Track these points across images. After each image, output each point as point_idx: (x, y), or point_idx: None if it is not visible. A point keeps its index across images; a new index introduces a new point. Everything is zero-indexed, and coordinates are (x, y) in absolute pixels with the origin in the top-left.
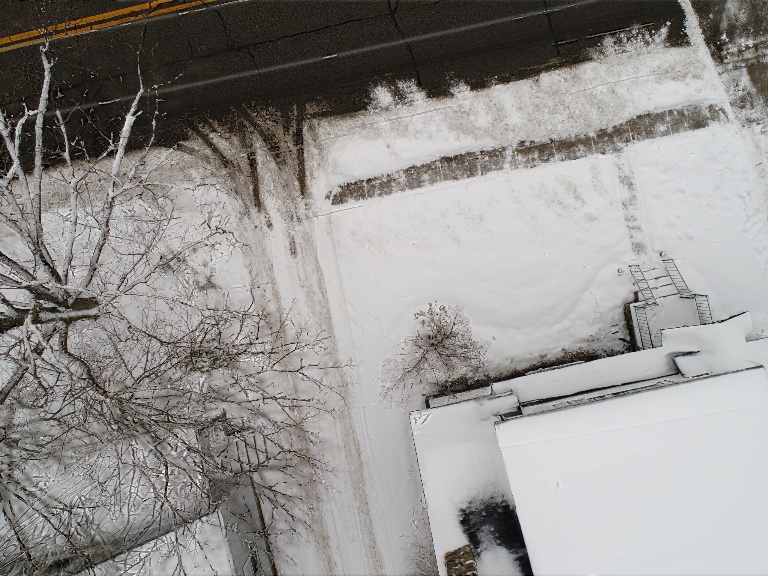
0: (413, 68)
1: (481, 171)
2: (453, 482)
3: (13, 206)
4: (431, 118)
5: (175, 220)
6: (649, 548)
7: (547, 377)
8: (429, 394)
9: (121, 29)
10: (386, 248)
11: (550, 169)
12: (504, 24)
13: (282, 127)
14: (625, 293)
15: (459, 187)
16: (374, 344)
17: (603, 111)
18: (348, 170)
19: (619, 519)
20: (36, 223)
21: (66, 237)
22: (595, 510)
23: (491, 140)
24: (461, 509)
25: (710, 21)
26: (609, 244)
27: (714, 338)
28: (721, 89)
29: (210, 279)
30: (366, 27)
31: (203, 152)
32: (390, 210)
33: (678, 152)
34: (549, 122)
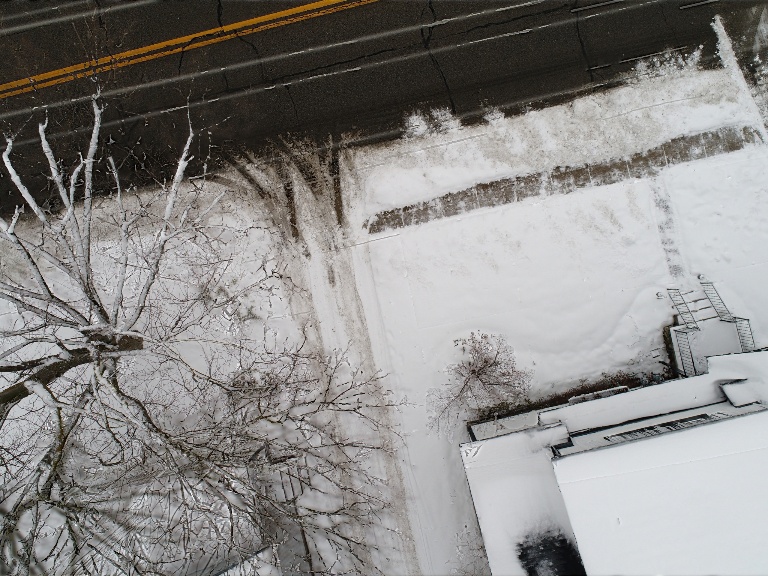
0: (447, 96)
1: (517, 197)
2: (509, 516)
3: (66, 250)
4: (467, 146)
5: None
6: None
7: (595, 406)
8: (470, 420)
9: (156, 63)
10: (424, 276)
11: (586, 194)
12: (537, 51)
13: (318, 157)
14: (664, 316)
15: (496, 214)
16: (414, 371)
17: (638, 136)
18: (385, 199)
19: (681, 555)
20: (86, 265)
21: (106, 270)
22: (657, 547)
23: (527, 167)
24: (518, 544)
25: (743, 43)
26: (647, 268)
27: (762, 366)
28: (755, 111)
29: (251, 310)
30: None
31: (240, 184)
32: (428, 238)
33: (714, 175)
34: (585, 148)
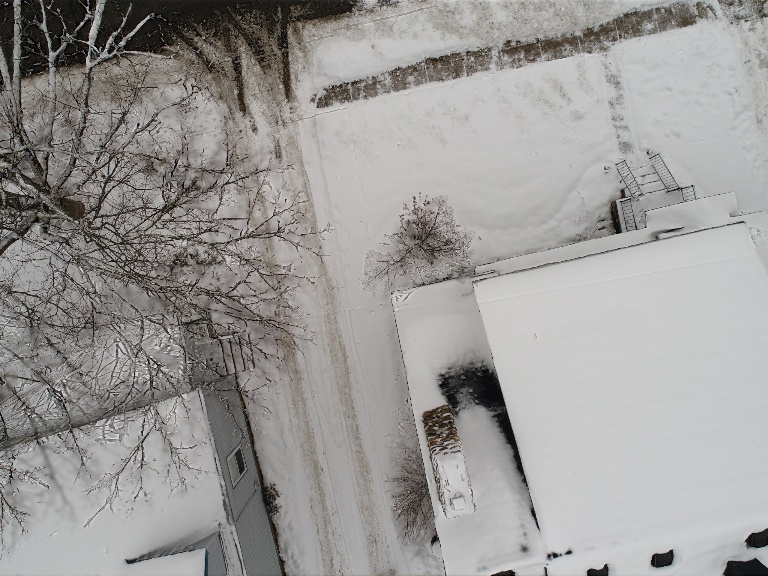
0: None
1: (467, 72)
2: (433, 350)
3: None
4: (416, 18)
5: (160, 125)
6: (626, 392)
7: (530, 258)
8: None
9: None
10: (371, 149)
11: (536, 68)
12: None
13: (267, 30)
14: (612, 191)
15: (444, 87)
16: (359, 246)
17: (589, 8)
18: (333, 71)
19: (597, 366)
20: (16, 104)
21: None
22: (573, 359)
23: (476, 39)
24: (440, 374)
25: None
26: (596, 142)
27: (698, 213)
28: None
29: None
30: None
31: (188, 56)
32: (375, 111)
33: (665, 49)
34: (535, 20)
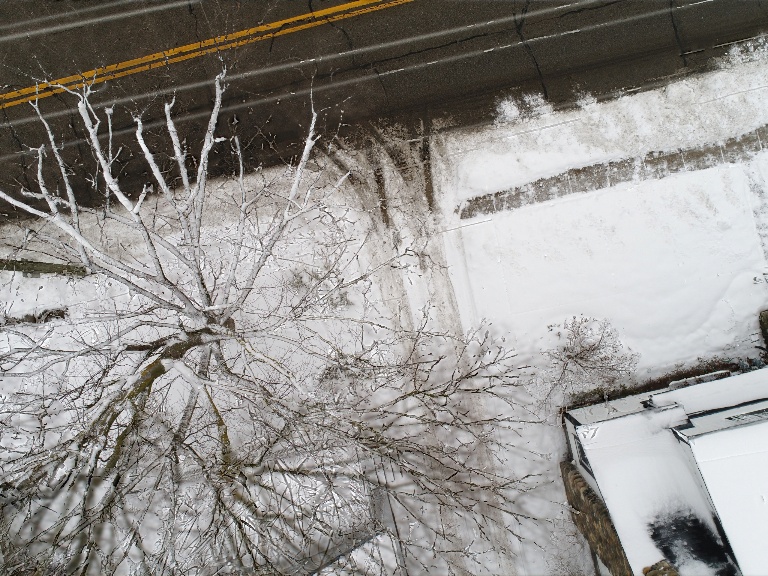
0: (539, 81)
1: (610, 182)
2: (636, 497)
3: (185, 231)
4: (560, 131)
5: None
6: None
7: (709, 389)
8: (563, 405)
9: None
10: (518, 261)
11: (681, 179)
12: (630, 36)
13: (409, 143)
14: (761, 301)
15: (590, 199)
16: None
17: (734, 120)
18: (478, 184)
19: None
20: None
21: None
22: None
23: (621, 151)
24: (649, 524)
25: None
26: (743, 253)
27: None
28: None
29: None
30: (492, 42)
31: (330, 169)
32: (521, 223)
33: None
34: (680, 132)
